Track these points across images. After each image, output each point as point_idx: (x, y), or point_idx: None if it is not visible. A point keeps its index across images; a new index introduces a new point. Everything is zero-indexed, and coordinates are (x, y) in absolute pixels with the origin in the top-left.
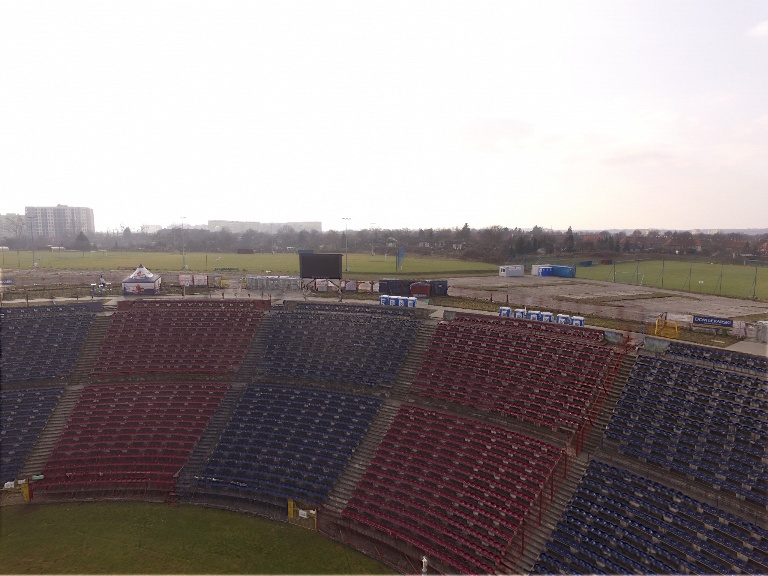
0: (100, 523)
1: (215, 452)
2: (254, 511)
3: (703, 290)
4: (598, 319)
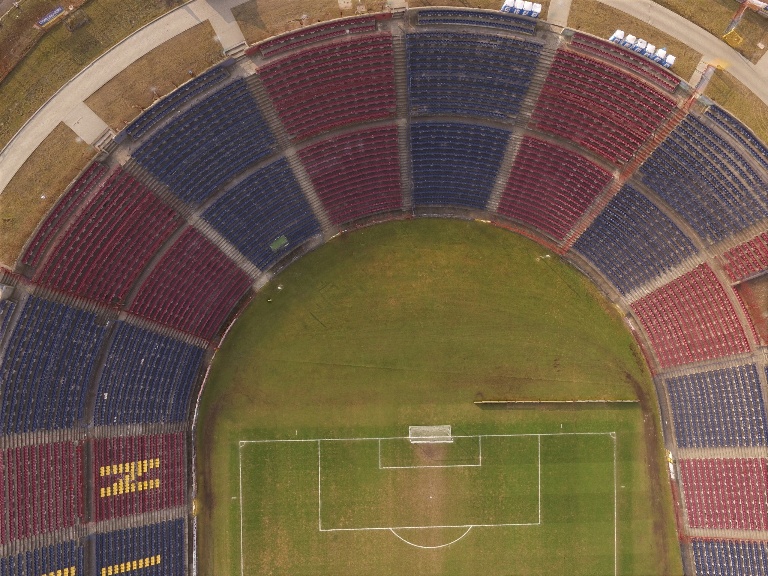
0: (386, 238)
1: (415, 183)
2: (451, 213)
3: None
4: None
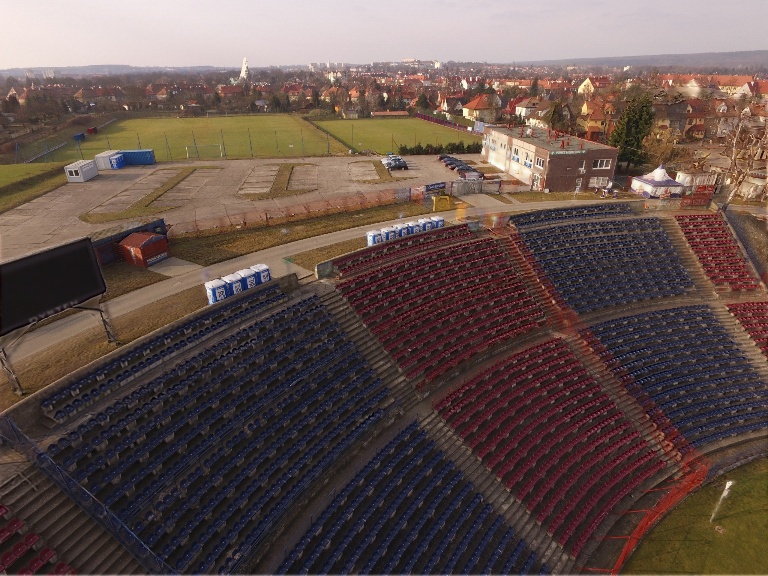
0: None
1: None
2: None
3: (296, 154)
4: (372, 211)
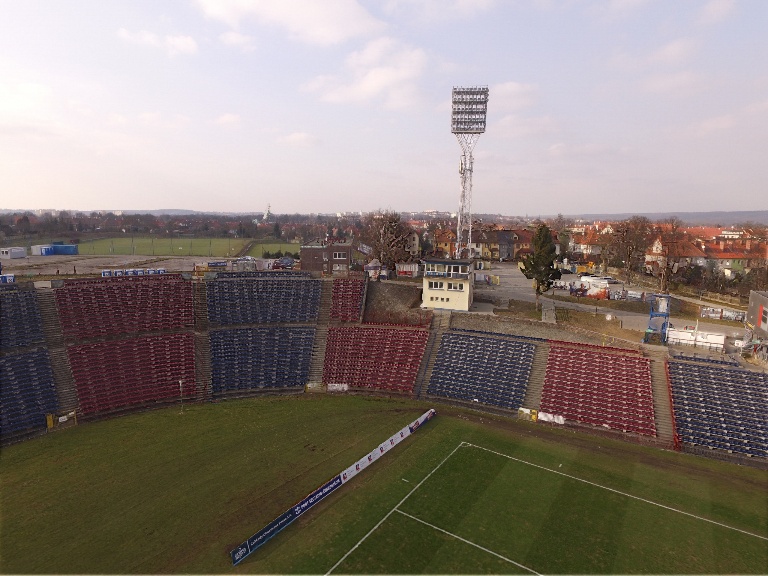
0: None
1: None
2: None
3: (183, 253)
4: None
